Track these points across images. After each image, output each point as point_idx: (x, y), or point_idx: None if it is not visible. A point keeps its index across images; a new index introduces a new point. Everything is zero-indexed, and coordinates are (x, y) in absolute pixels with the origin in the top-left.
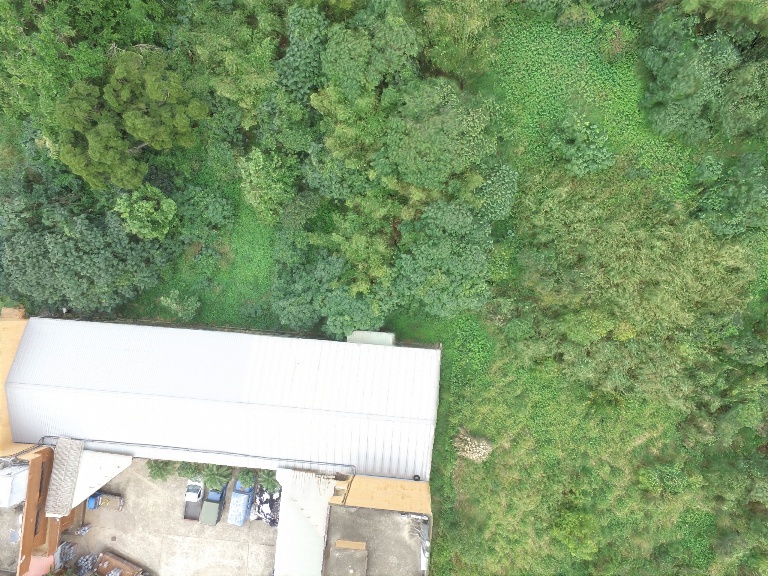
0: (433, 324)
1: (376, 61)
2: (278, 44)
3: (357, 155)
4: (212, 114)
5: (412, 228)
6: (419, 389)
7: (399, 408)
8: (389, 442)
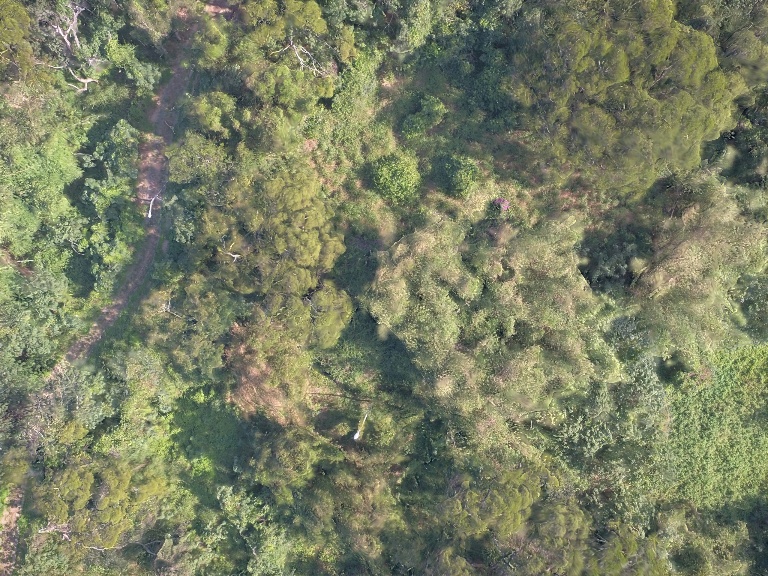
0: None
1: None
2: None
3: None
4: None
5: None
6: None
7: None
8: None
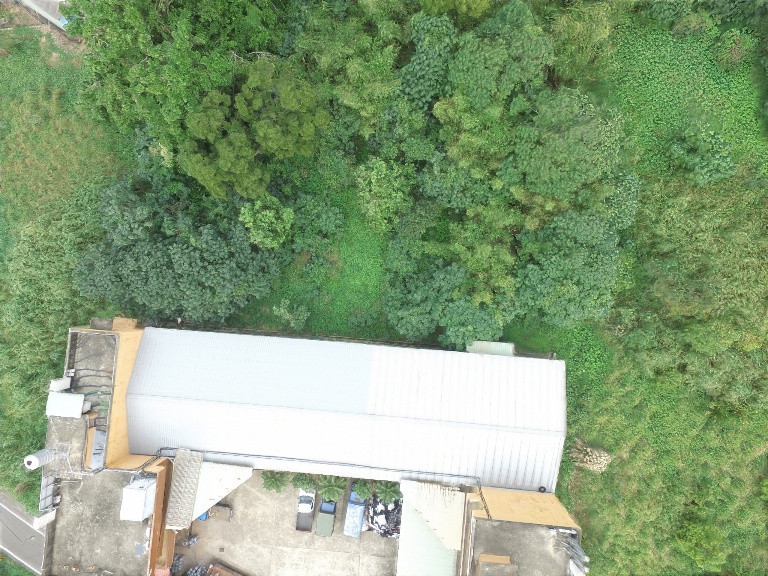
0: (547, 334)
1: (511, 70)
2: (399, 52)
3: (478, 164)
4: None
5: (534, 238)
6: (547, 400)
7: (528, 420)
8: (517, 454)
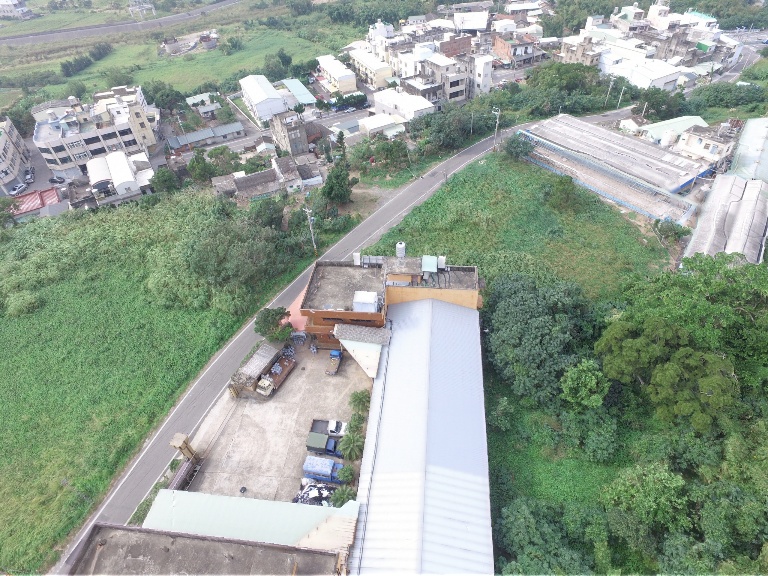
0: None
1: None
2: None
3: None
4: (698, 437)
5: None
6: None
7: None
8: None
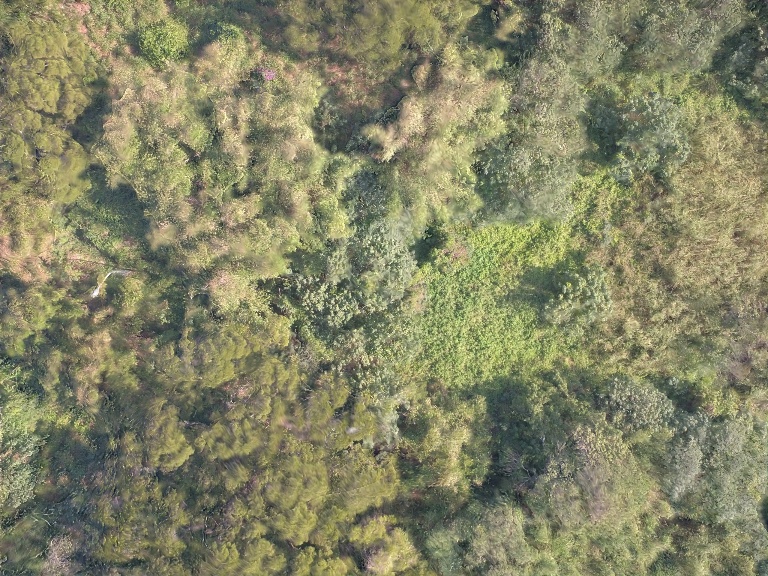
0: None
1: (517, 554)
2: None
3: (589, 565)
4: None
5: (674, 501)
6: None
7: None
8: None
